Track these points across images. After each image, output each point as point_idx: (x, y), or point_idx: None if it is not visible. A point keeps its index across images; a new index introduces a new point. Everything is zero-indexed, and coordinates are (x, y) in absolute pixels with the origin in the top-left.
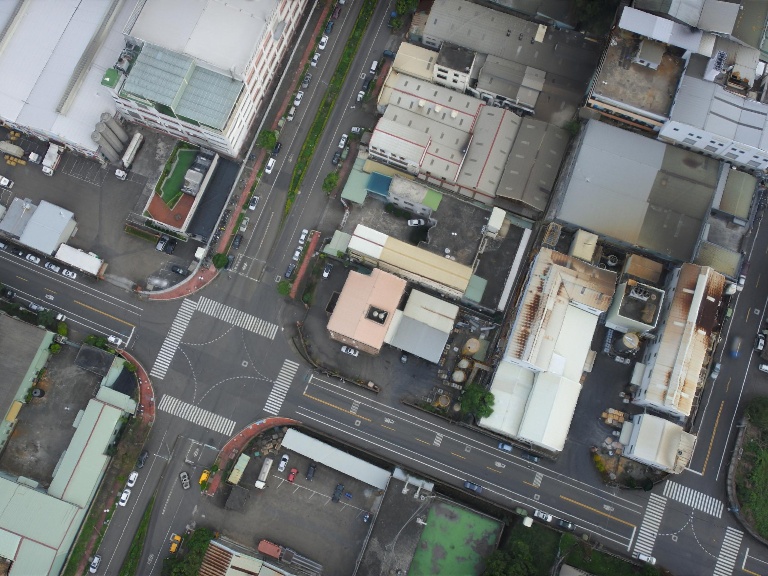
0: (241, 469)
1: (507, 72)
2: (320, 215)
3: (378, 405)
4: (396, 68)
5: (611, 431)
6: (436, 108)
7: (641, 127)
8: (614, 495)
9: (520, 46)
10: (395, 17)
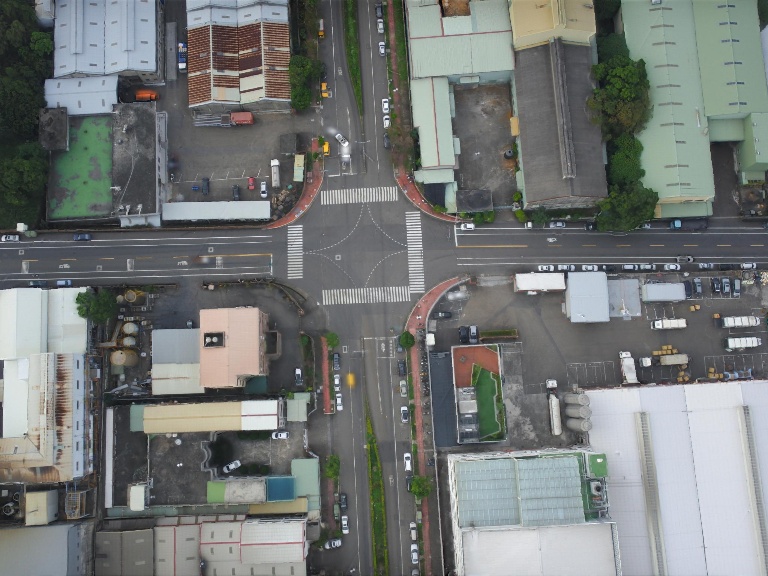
0: (297, 168)
1: None
2: (334, 432)
3: (198, 273)
4: None
5: None
6: None
7: None
8: None
9: None
10: None
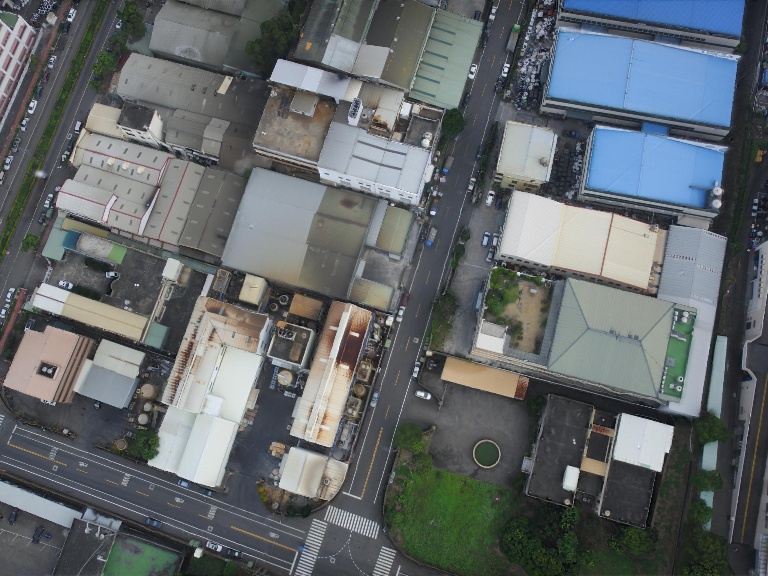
0: None
1: (189, 126)
2: (27, 273)
3: (74, 450)
4: (89, 129)
5: (278, 463)
6: (123, 165)
7: (310, 170)
8: (280, 523)
9: (205, 99)
10: (98, 77)
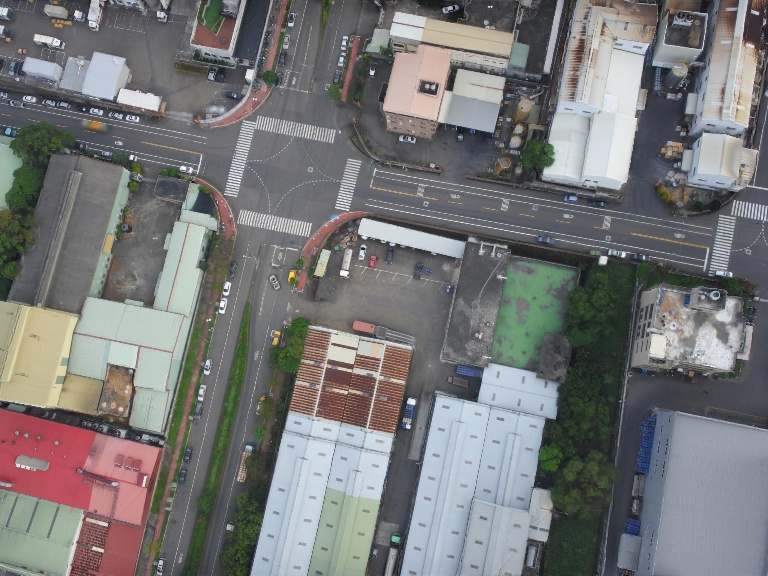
0: (324, 263)
1: None
2: (357, 20)
3: (442, 184)
4: None
5: (672, 165)
6: None
7: None
8: (683, 223)
9: None
10: None
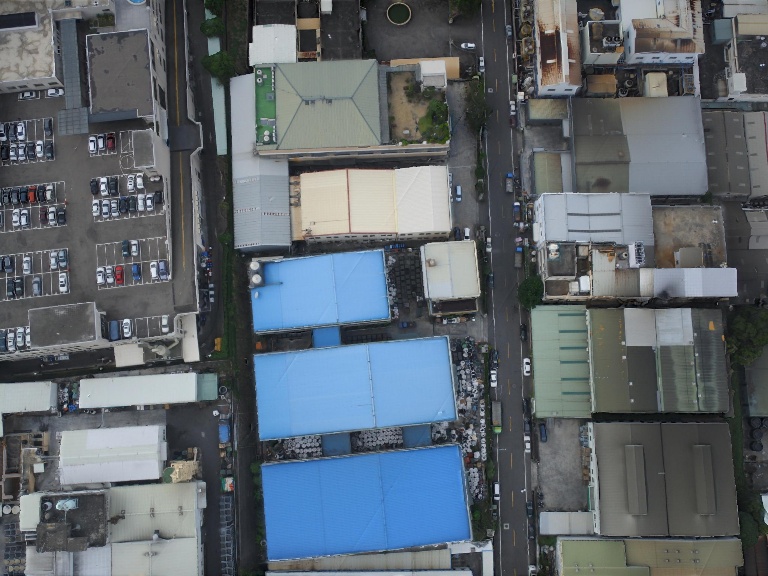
0: None
1: None
2: None
3: None
4: None
5: None
6: None
7: None
8: None
9: None
10: None
